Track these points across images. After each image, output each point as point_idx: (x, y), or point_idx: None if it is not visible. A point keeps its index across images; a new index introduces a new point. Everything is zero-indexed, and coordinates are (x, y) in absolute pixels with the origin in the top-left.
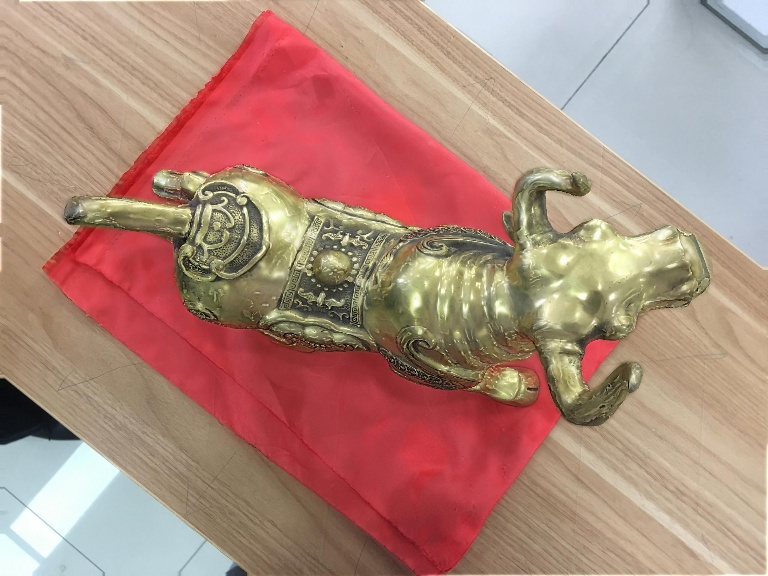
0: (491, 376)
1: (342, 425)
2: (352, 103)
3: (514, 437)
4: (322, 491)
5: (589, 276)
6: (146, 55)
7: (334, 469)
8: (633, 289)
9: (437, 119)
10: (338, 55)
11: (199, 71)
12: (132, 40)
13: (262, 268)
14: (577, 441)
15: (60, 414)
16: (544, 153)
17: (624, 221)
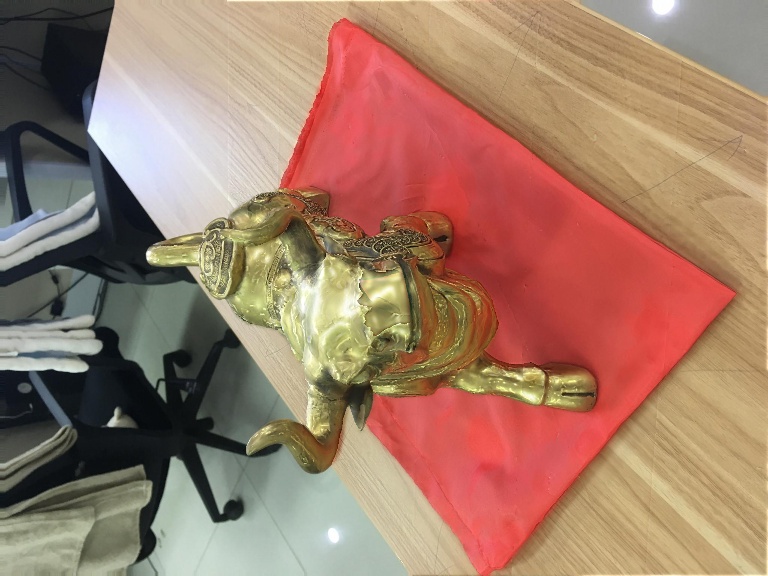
0: (505, 378)
1: (420, 407)
2: (403, 90)
3: (566, 445)
4: (407, 464)
5: (309, 319)
6: (285, 88)
7: (415, 446)
8: (342, 334)
9: (485, 82)
10: (400, 40)
11: (313, 91)
12: (277, 78)
13: (246, 287)
14: (647, 463)
15: (268, 374)
16: (601, 92)
17: (714, 167)
